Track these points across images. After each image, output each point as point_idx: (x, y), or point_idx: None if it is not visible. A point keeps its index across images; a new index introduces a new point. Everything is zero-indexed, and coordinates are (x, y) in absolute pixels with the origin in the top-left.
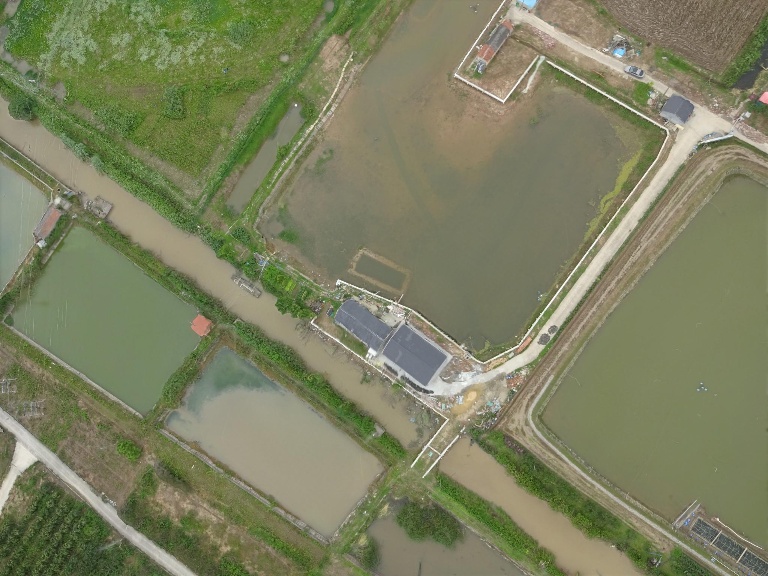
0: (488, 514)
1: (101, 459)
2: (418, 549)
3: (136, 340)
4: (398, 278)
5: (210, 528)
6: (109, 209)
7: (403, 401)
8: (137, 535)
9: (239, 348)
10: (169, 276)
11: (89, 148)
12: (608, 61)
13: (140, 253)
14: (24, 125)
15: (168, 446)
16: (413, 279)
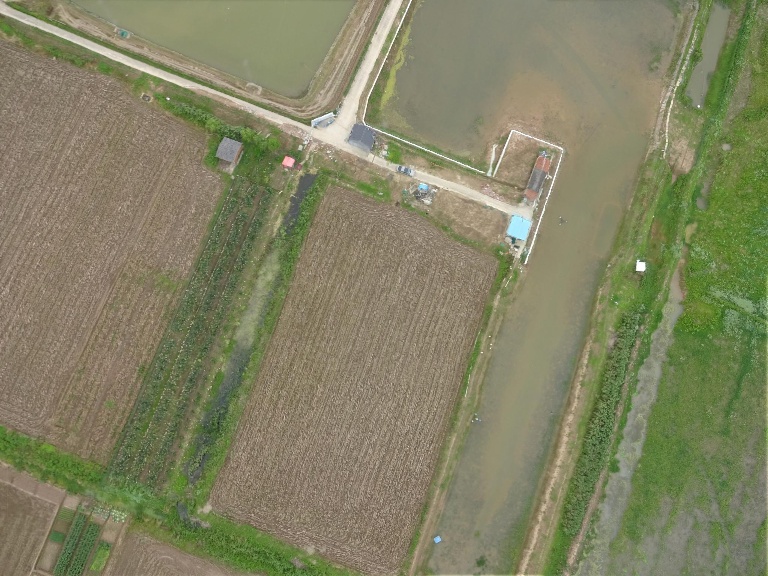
0: None
1: None
2: None
3: None
4: None
5: None
6: None
7: None
8: None
9: None
10: None
11: None
12: (431, 179)
13: None
14: None
15: None
16: None
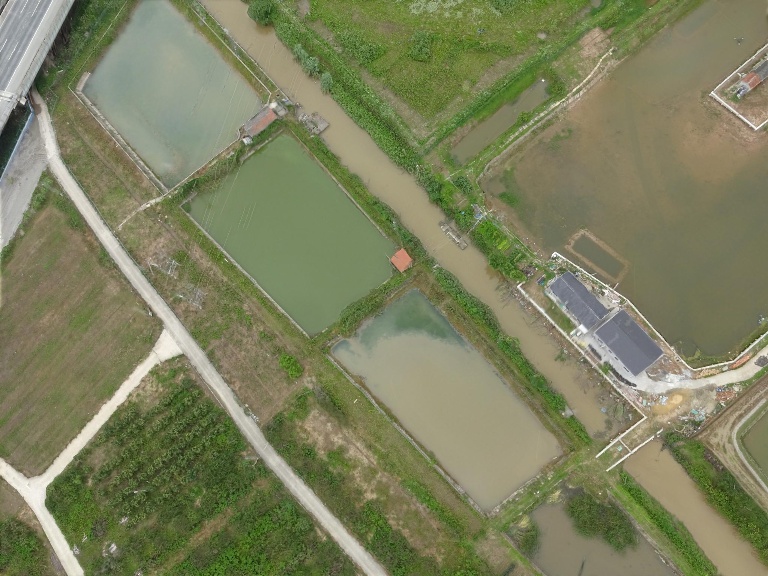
0: (672, 525)
1: (254, 369)
2: (584, 546)
3: (321, 259)
4: (615, 266)
5: (358, 470)
6: (325, 127)
7: (597, 388)
8: (275, 458)
9: (433, 293)
10: (375, 205)
11: (321, 65)
12: None
13: (350, 175)
14: (251, 29)
15: (332, 373)
16: (631, 271)
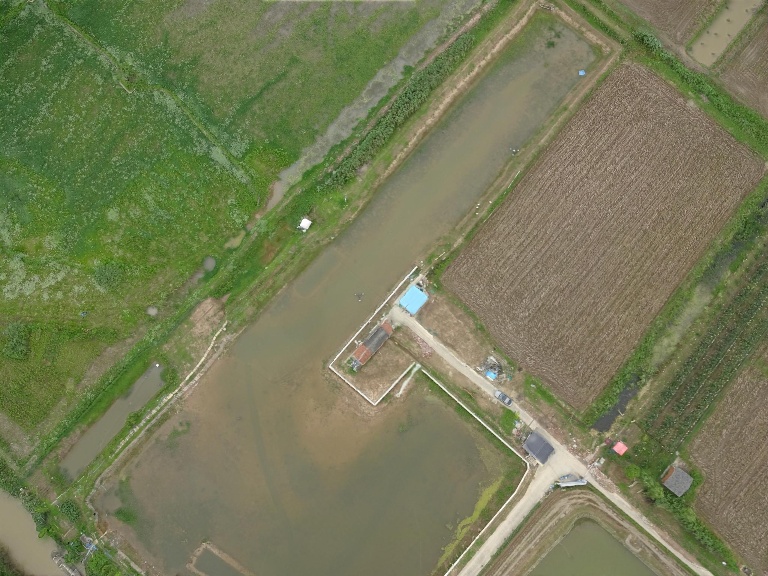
0: None
1: None
2: None
3: None
4: None
5: None
6: None
7: None
8: None
9: None
10: None
11: None
12: (480, 382)
13: None
14: None
15: None
16: None
